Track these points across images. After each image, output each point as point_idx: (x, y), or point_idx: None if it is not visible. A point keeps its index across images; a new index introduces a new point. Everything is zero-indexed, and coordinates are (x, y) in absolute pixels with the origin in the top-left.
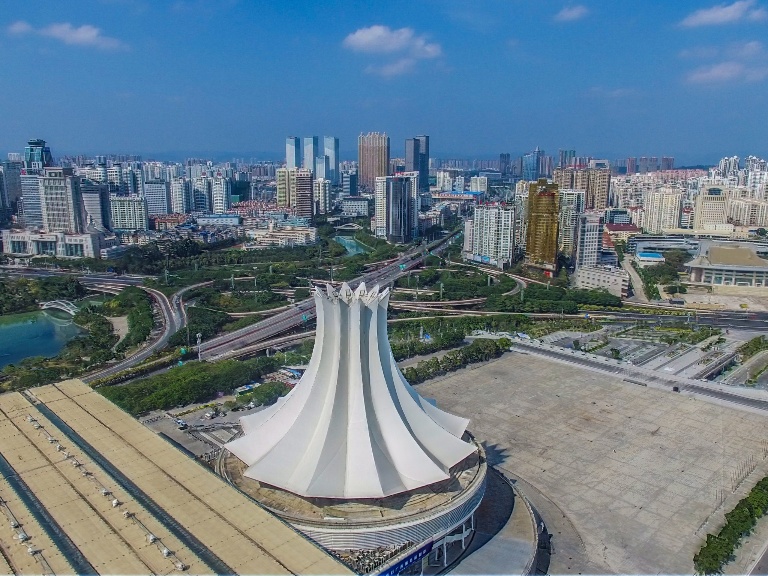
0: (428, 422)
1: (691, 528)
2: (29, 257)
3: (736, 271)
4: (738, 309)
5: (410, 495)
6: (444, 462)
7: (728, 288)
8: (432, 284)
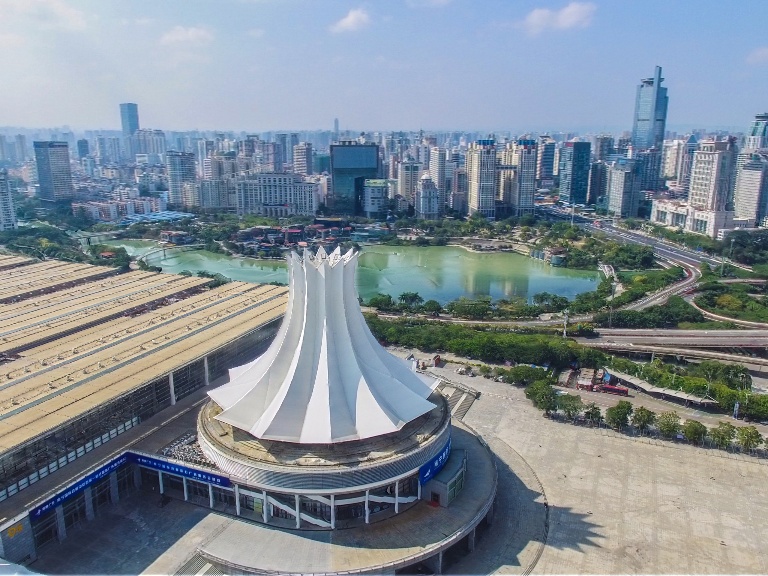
0: (324, 397)
1: None
2: (662, 227)
3: None
4: None
5: (255, 439)
6: (303, 436)
7: None
8: None
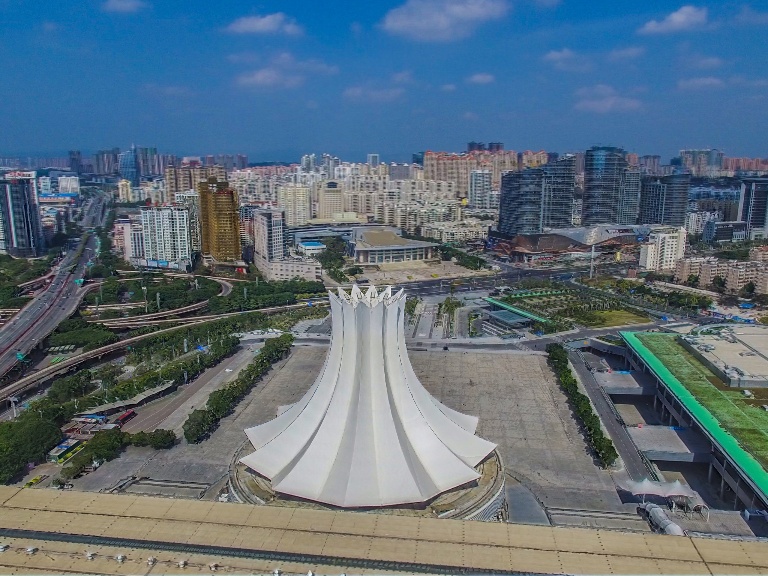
0: (440, 406)
1: (565, 441)
2: None
3: (393, 250)
4: (408, 281)
5: None
6: None
7: (390, 265)
8: (121, 297)
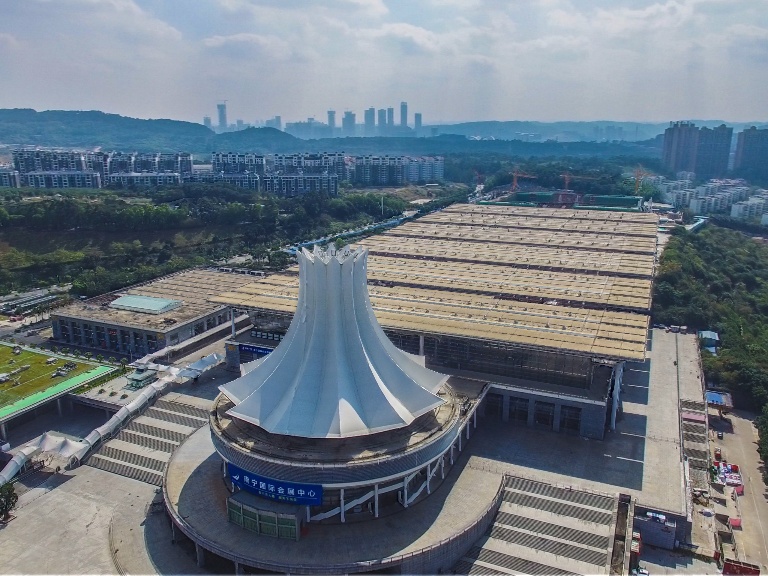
0: None
1: None
2: None
3: None
4: None
5: None
6: None
7: None
8: None
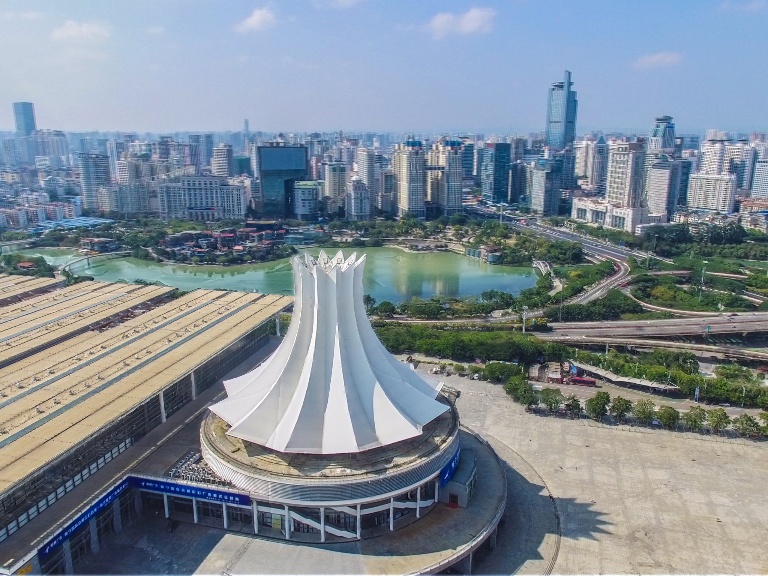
0: (342, 405)
1: None
2: (583, 224)
3: None
4: None
5: (271, 453)
6: (325, 446)
7: None
8: None
